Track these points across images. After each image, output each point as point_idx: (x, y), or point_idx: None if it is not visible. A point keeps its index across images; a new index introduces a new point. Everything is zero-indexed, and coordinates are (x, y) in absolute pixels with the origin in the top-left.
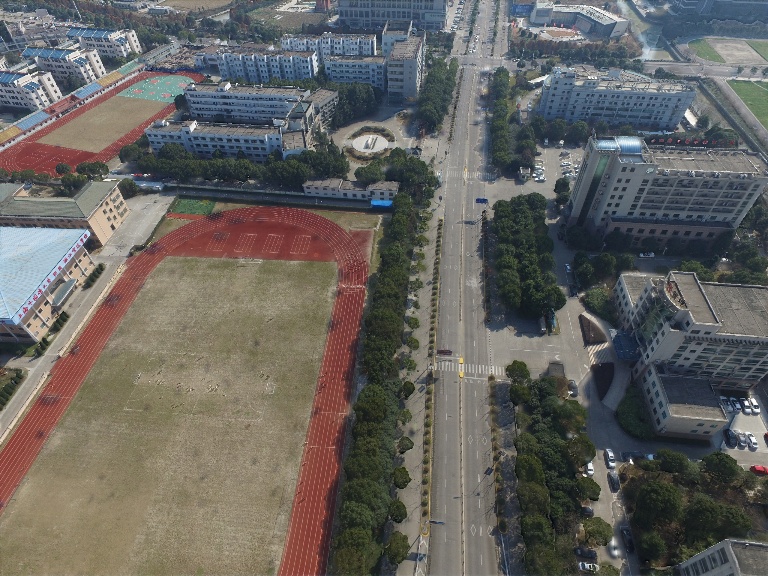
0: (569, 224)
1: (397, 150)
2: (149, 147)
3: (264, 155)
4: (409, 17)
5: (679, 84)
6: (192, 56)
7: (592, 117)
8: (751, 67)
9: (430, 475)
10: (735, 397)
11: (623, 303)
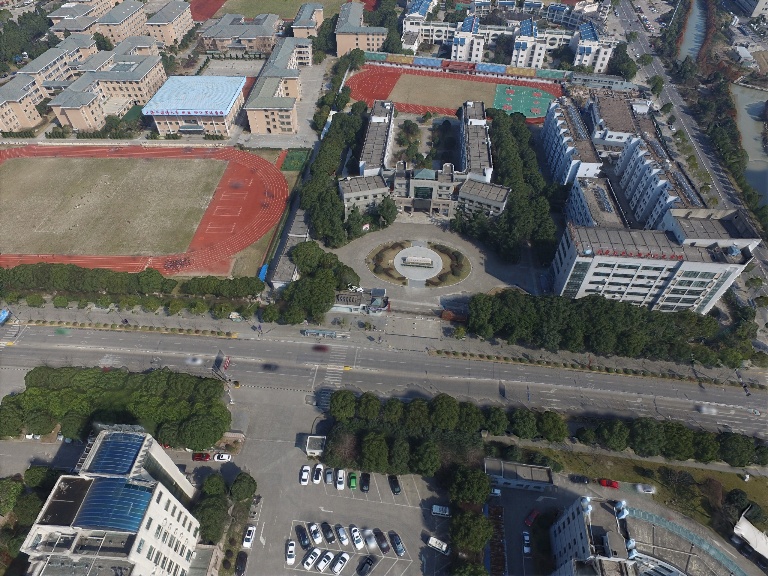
0: None
1: (344, 269)
2: None
3: None
4: None
5: None
6: None
7: None
8: None
9: None
10: None
11: None
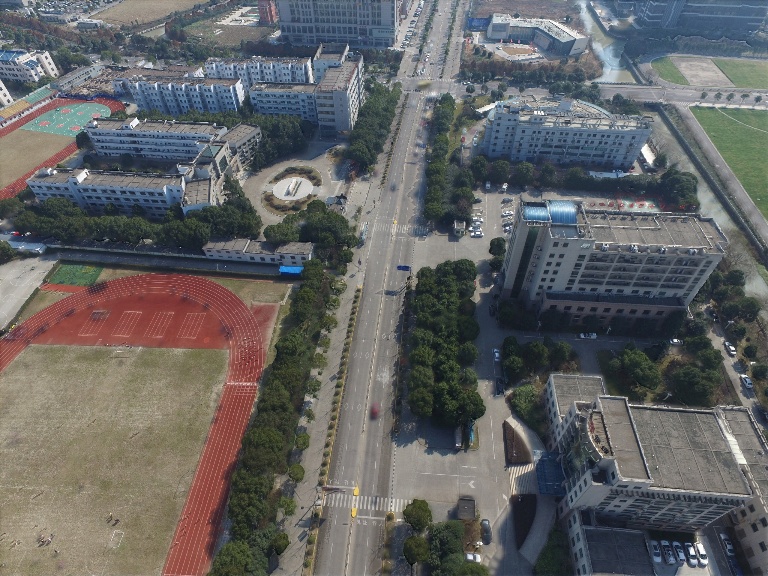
0: (502, 295)
1: (314, 203)
2: (35, 198)
3: (165, 208)
4: (356, 33)
5: (633, 120)
6: None
7: (540, 155)
8: (716, 90)
9: None
10: (679, 541)
11: (552, 412)
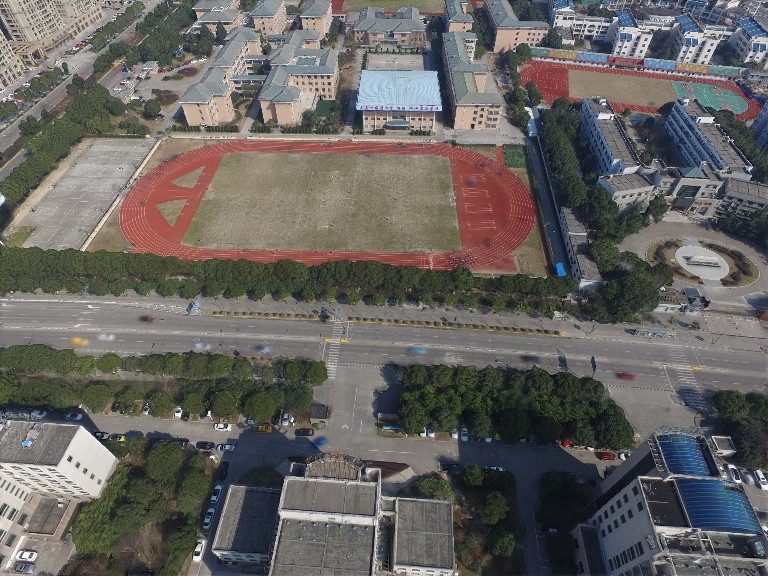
0: None
1: (661, 268)
2: None
3: None
4: None
5: None
6: None
7: None
8: None
9: (241, 316)
10: None
11: None
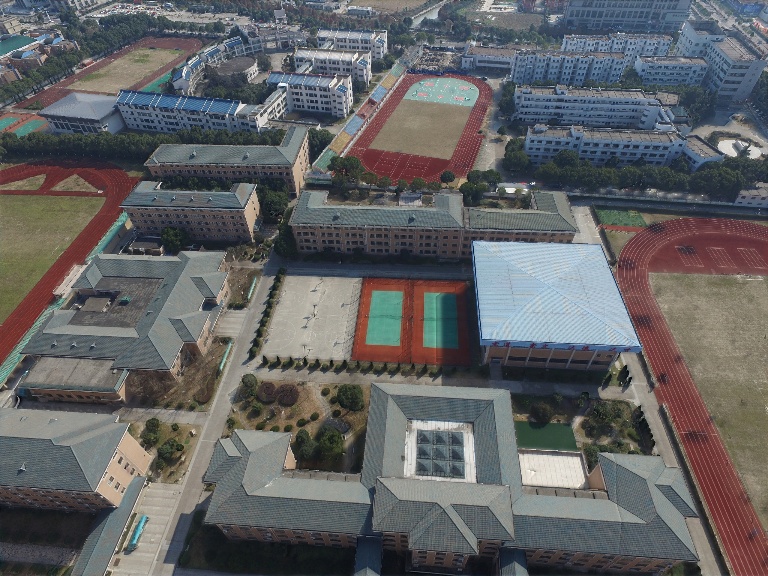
0: None
1: None
2: None
3: (658, 162)
4: (646, 17)
5: None
6: (442, 58)
7: None
8: None
9: None
10: None
11: None
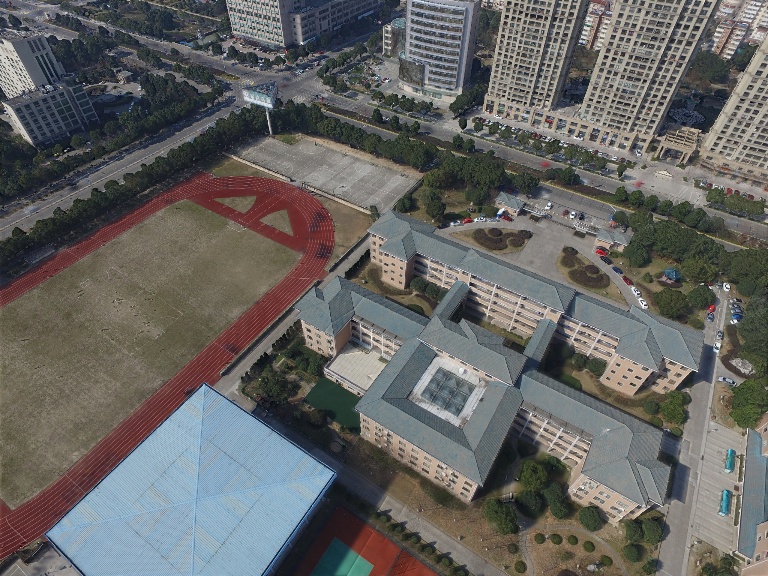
0: None
1: None
2: None
3: None
4: None
5: None
6: None
7: None
8: None
9: None
10: None
11: None
